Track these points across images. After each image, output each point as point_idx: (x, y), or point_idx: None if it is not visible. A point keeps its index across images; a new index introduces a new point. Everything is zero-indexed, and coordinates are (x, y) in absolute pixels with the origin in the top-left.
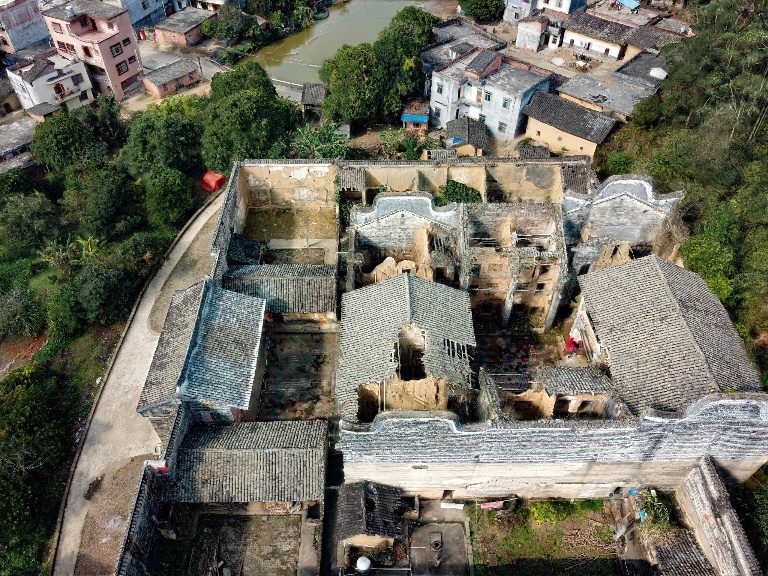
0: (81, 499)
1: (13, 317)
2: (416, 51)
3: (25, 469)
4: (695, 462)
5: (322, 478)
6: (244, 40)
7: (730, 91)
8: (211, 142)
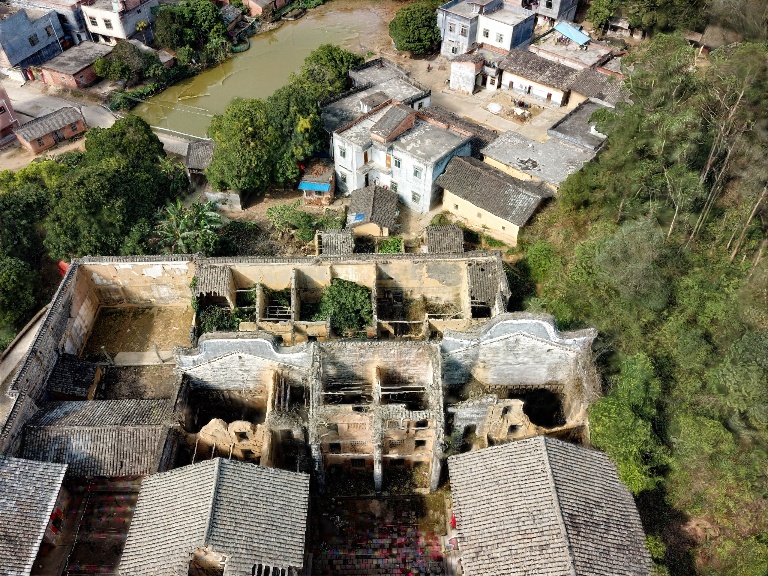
0: None
1: None
2: (314, 108)
3: None
4: None
5: None
6: (147, 79)
7: (666, 180)
8: (54, 229)
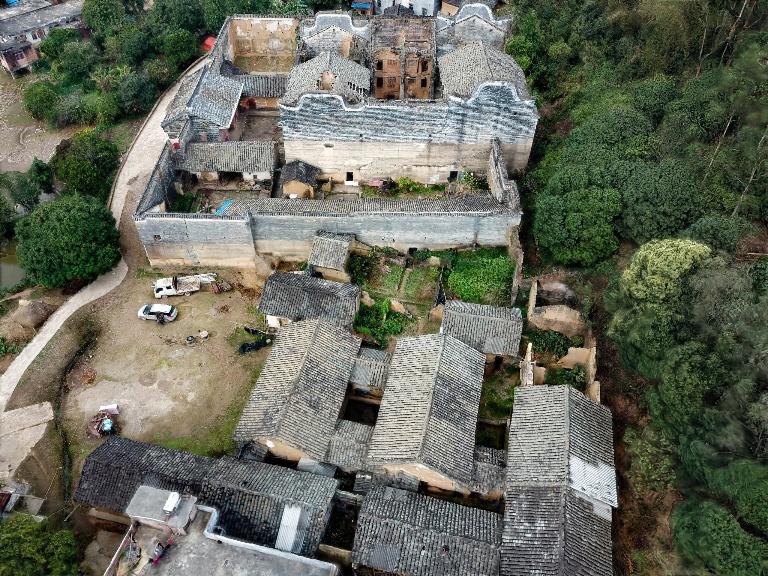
0: (125, 185)
1: (74, 108)
2: None
3: (92, 159)
4: (490, 144)
5: (272, 160)
6: None
7: None
8: (211, 8)
